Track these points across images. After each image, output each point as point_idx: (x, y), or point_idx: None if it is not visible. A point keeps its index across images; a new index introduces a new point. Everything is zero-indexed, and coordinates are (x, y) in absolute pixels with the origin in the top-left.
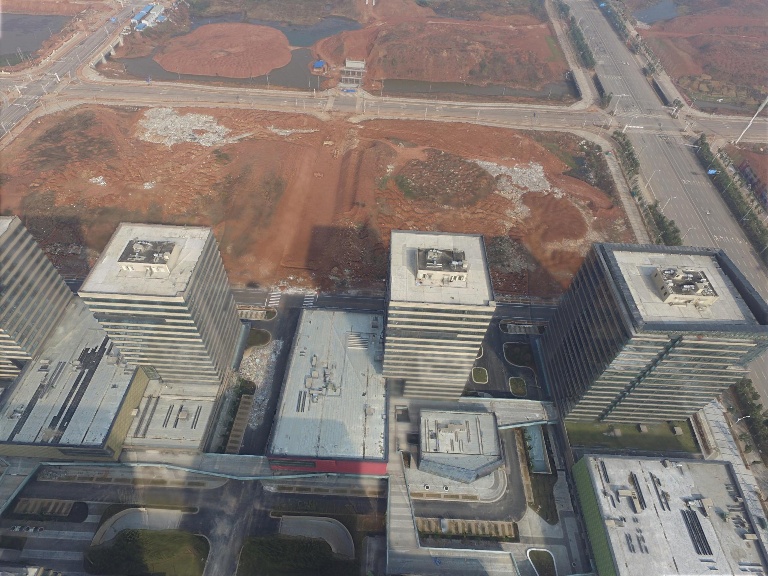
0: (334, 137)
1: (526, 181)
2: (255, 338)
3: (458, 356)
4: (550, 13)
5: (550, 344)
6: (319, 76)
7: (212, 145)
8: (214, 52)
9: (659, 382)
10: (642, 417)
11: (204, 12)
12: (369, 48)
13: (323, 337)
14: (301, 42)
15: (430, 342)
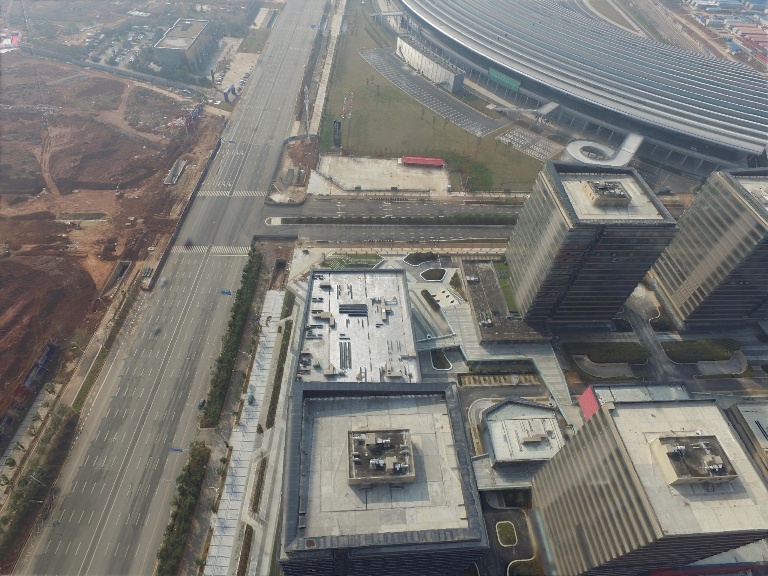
0: None
1: None
2: None
3: None
4: None
5: None
6: None
7: None
8: None
9: None
10: None
11: None
12: None
13: None
14: None
15: None
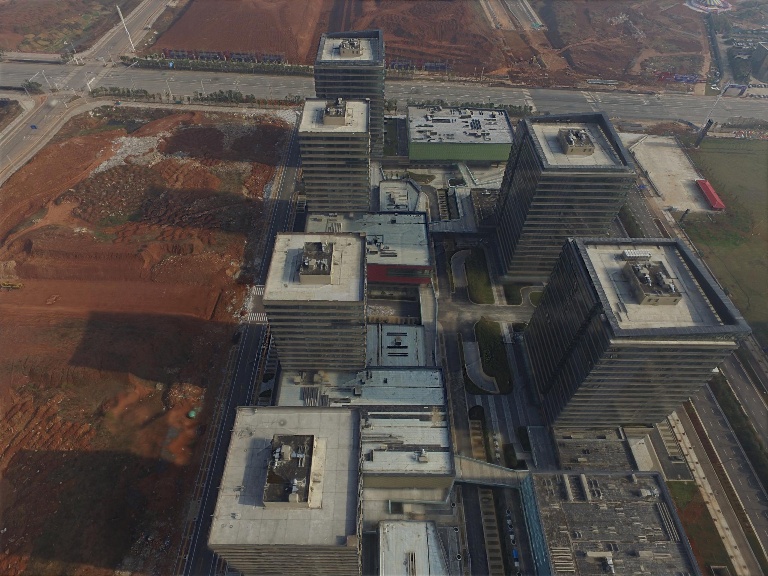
0: None
1: (141, 148)
2: None
3: None
4: None
5: None
6: None
7: None
8: None
9: None
10: None
11: None
12: None
13: None
14: None
15: None
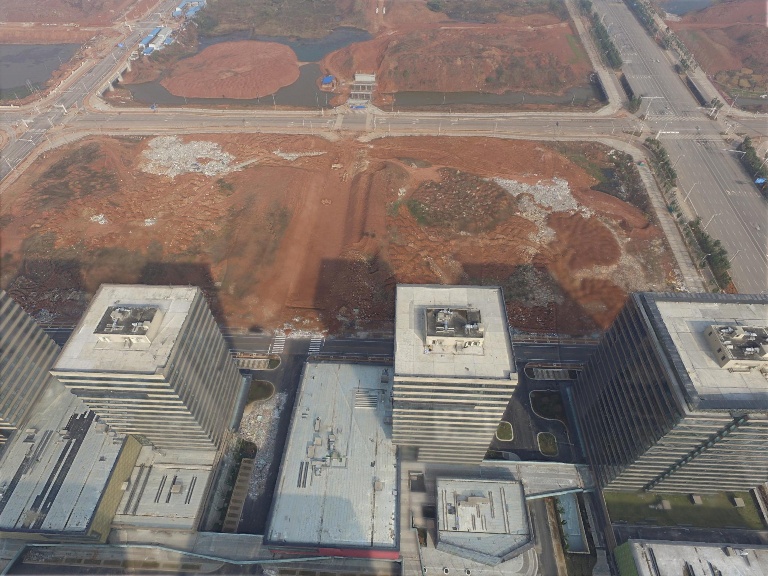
0: (343, 159)
1: (550, 200)
2: (257, 392)
3: (477, 426)
4: (571, 10)
5: (583, 397)
6: (328, 92)
7: (216, 174)
8: (221, 73)
9: (717, 457)
10: (695, 488)
11: (212, 31)
12: (379, 60)
13: (327, 395)
14: (309, 57)
15: (444, 413)
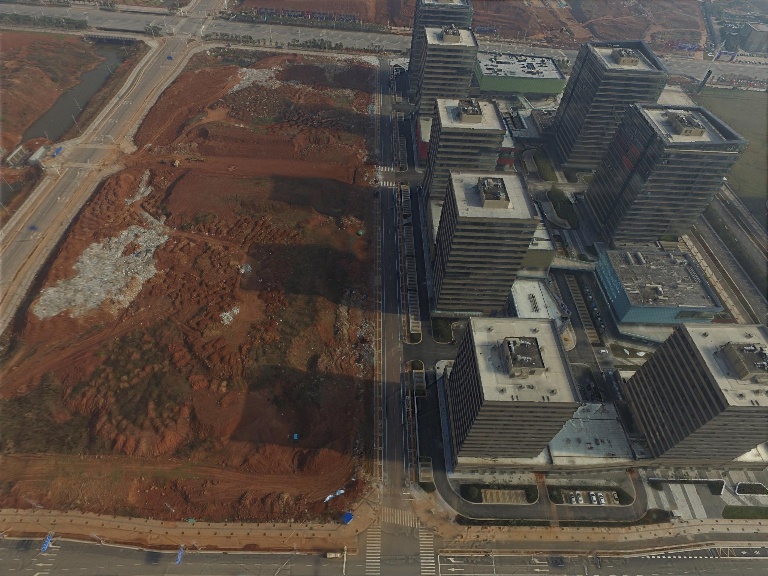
0: None
1: (262, 76)
2: None
3: None
4: None
5: None
6: None
7: (166, 235)
8: None
9: None
10: None
11: None
12: None
13: None
14: None
15: None
